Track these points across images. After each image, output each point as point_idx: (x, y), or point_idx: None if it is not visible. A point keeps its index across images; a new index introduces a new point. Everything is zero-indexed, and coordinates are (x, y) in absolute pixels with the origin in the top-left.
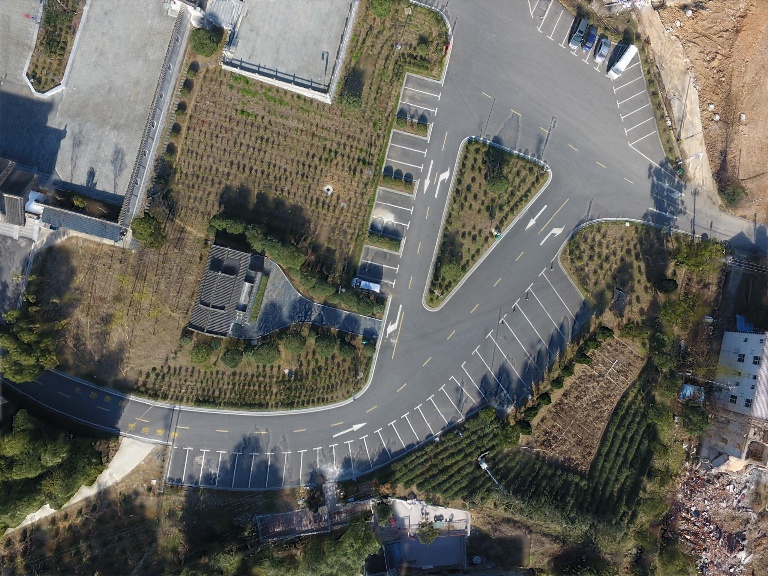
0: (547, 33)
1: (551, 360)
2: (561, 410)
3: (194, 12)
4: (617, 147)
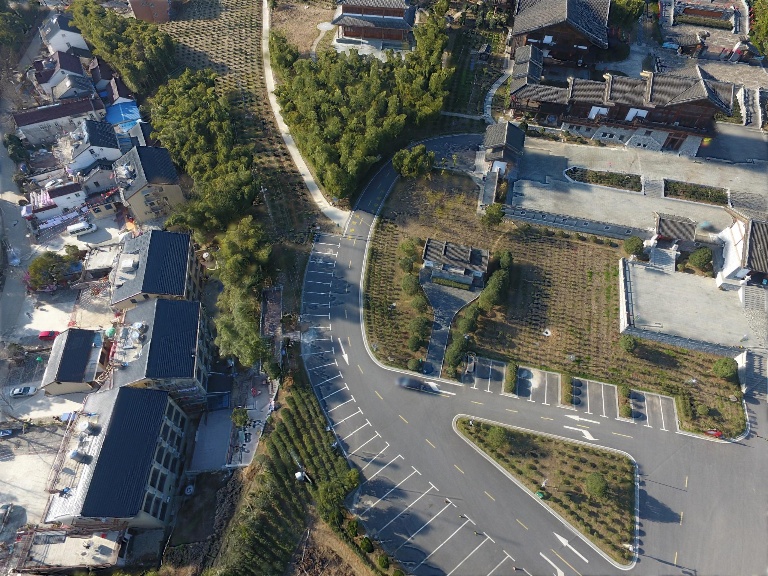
0: None
1: (408, 567)
2: None
3: (653, 240)
4: None
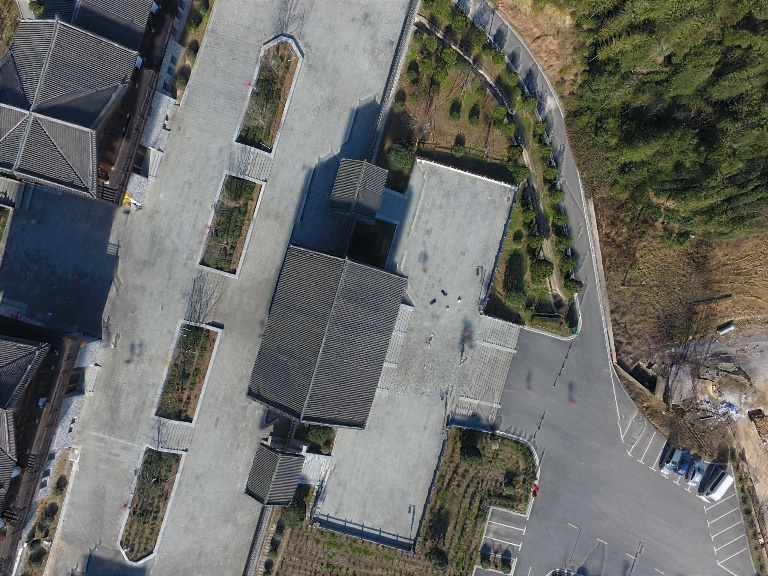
0: (637, 457)
1: None
2: None
3: None
4: (705, 567)
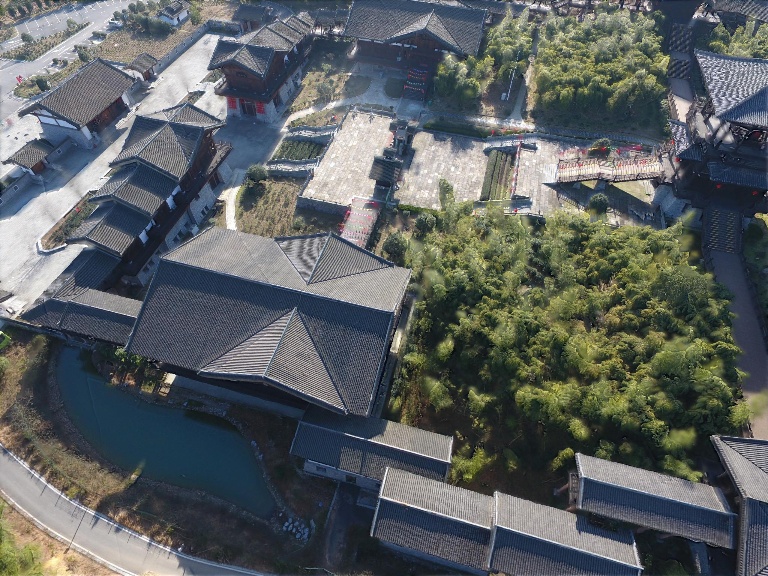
0: None
1: None
2: (52, 5)
3: None
4: None
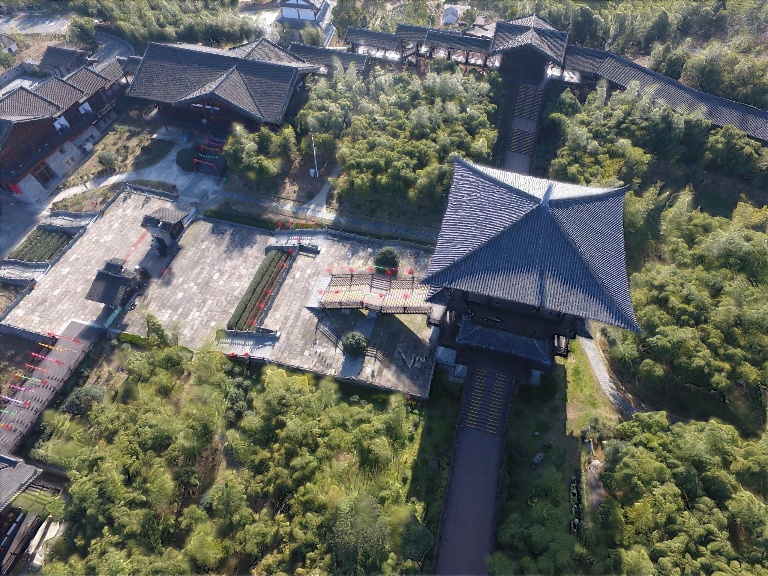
0: None
1: None
2: None
3: None
4: None
